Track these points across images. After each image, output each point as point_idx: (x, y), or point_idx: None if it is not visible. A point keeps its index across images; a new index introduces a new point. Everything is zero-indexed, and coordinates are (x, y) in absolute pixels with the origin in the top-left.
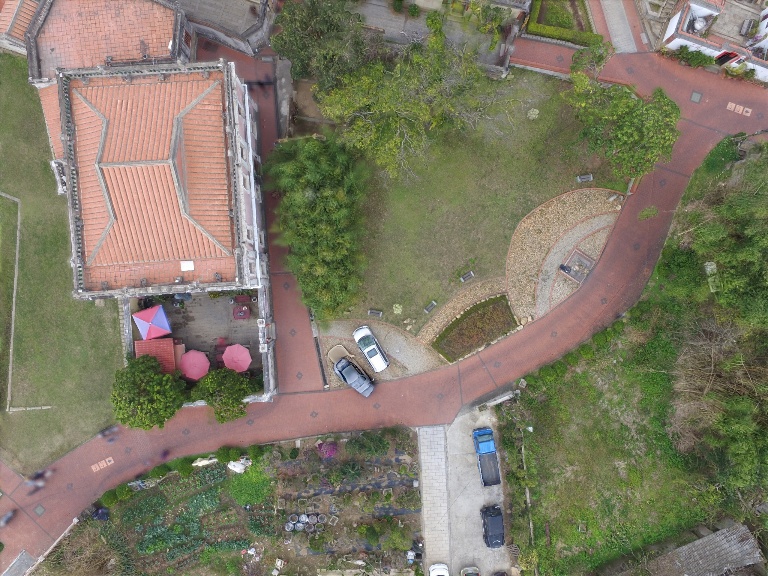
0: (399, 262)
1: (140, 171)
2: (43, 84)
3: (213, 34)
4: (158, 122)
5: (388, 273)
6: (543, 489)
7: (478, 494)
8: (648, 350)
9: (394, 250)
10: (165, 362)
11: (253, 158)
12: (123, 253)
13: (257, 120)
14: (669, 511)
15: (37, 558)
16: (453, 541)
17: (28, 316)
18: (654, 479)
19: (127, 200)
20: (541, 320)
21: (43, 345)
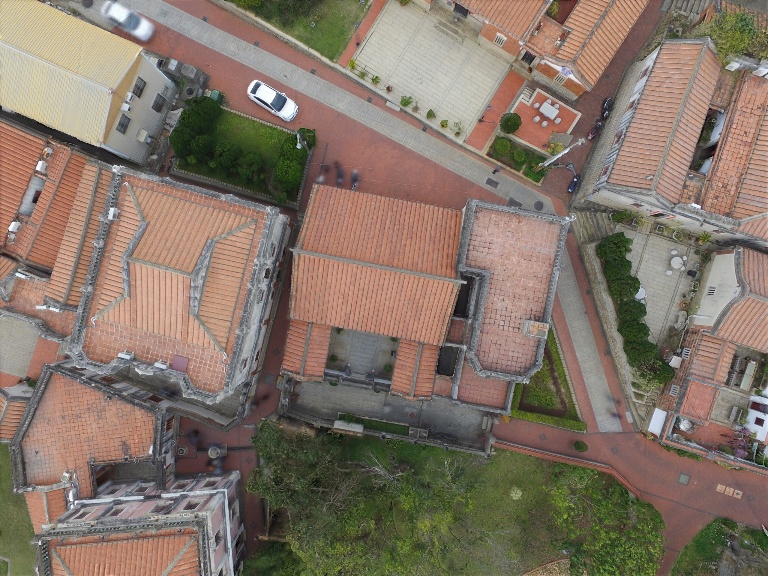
0: None
1: None
2: None
3: None
4: None
5: None
6: None
7: None
8: None
9: None
10: None
11: (235, 544)
12: None
13: (240, 486)
14: None
15: None
16: None
17: None
18: None
19: None
20: None
21: None
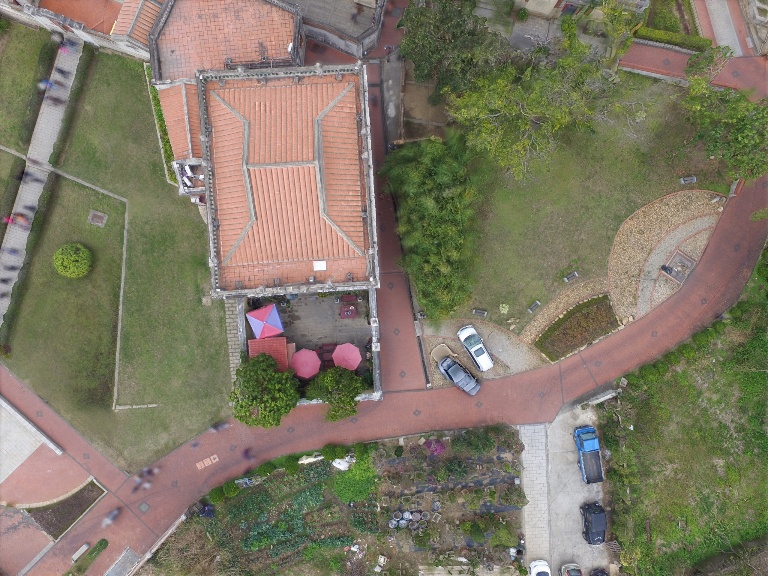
0: (504, 262)
1: (285, 172)
2: (164, 85)
3: (324, 37)
4: (298, 124)
5: (492, 273)
6: (643, 486)
7: (578, 491)
8: (748, 350)
9: (499, 250)
10: (278, 361)
11: None
12: (259, 253)
13: None
14: (767, 508)
15: (141, 555)
16: (553, 538)
17: (135, 315)
18: (751, 477)
19: (269, 201)
20: (642, 320)
21: (150, 344)
